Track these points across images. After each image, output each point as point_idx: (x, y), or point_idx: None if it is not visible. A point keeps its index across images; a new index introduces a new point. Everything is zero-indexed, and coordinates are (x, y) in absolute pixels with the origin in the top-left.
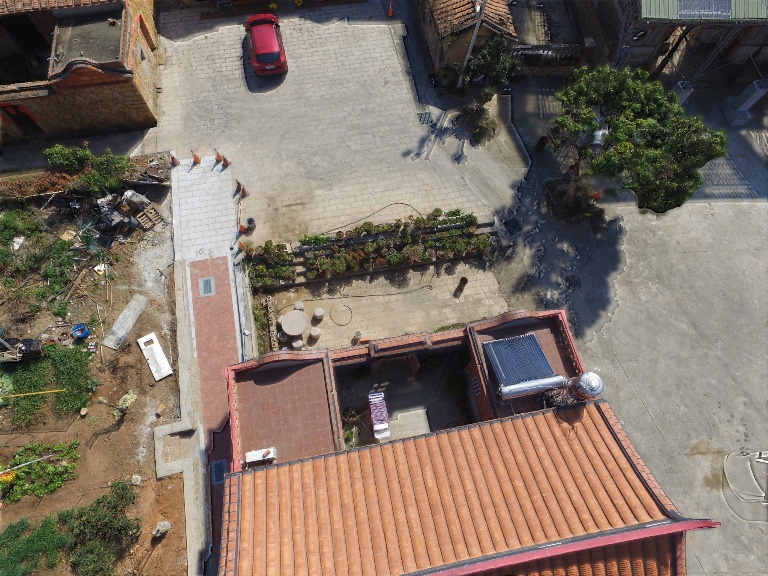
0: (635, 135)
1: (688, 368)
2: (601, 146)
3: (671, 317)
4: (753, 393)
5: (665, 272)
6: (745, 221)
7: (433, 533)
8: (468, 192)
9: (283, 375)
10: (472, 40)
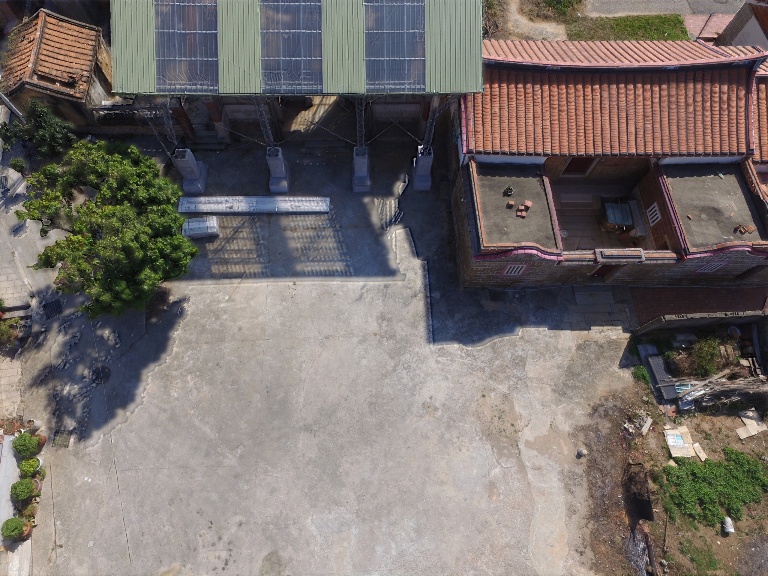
0: (96, 225)
1: (192, 480)
2: (198, 214)
3: (197, 418)
4: (254, 511)
5: (211, 364)
6: (327, 304)
7: None
8: (11, 269)
9: None
10: (7, 104)
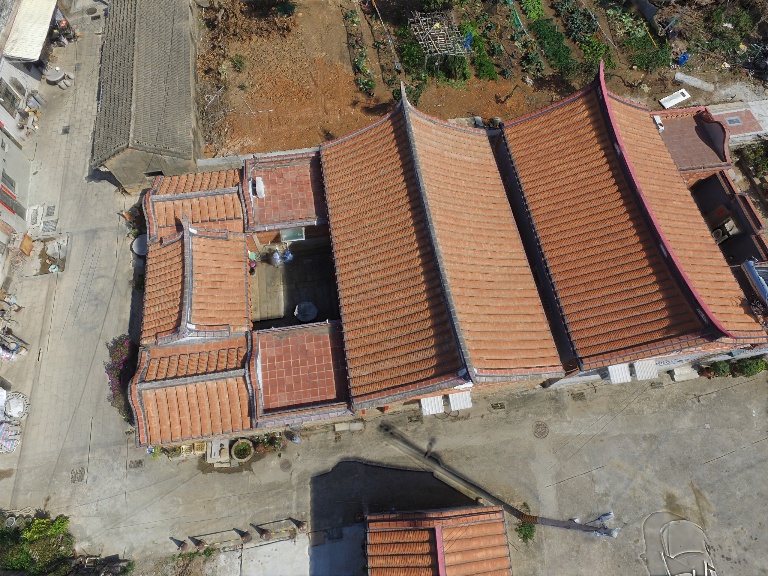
0: None
1: None
2: None
3: None
4: None
5: None
6: None
7: (650, 195)
8: None
9: (706, 141)
10: None
